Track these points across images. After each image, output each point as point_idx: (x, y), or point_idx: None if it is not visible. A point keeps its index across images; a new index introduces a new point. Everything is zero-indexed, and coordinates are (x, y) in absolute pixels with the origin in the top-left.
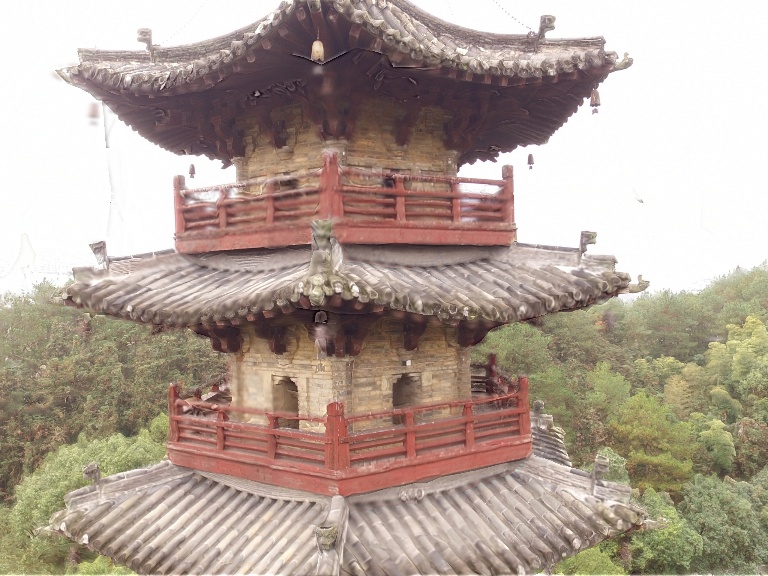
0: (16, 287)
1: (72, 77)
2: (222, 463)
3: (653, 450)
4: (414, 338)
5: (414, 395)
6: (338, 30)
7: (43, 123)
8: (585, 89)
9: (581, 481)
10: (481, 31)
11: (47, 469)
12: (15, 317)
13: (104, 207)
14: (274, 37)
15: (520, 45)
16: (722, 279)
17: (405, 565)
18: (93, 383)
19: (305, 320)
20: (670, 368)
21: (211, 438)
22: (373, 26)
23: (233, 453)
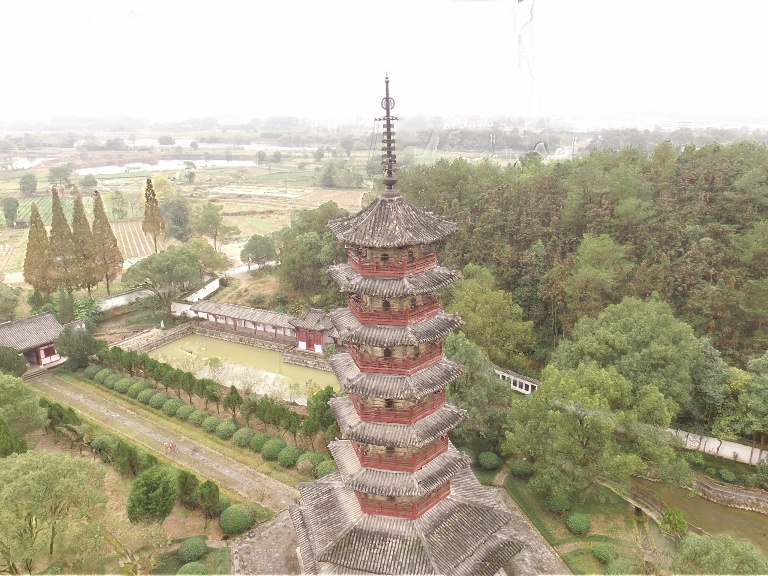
0: (428, 161)
1: None
2: None
3: None
4: None
5: None
6: None
7: (473, 4)
8: None
9: None
10: None
11: None
12: None
13: (513, 72)
14: None
15: None
16: None
17: (365, 337)
18: None
19: None
20: None
21: None
22: (354, 243)
23: None
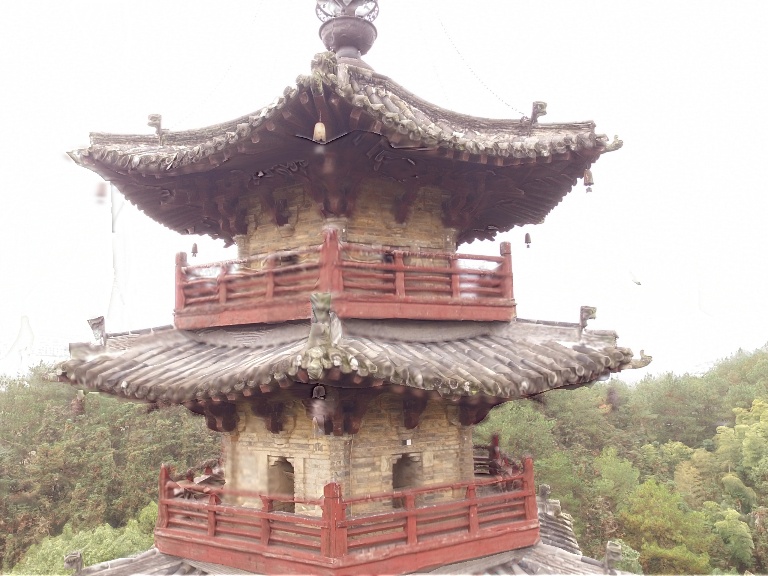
0: (12, 370)
1: (82, 158)
2: (212, 551)
3: (667, 542)
4: (414, 416)
5: (415, 477)
6: (339, 113)
7: (52, 209)
8: (578, 169)
9: (593, 571)
10: (476, 117)
11: (28, 563)
12: (8, 401)
13: (106, 290)
14: (278, 119)
15: (514, 129)
16: (725, 361)
17: None
18: (83, 470)
19: (303, 395)
20: (679, 454)
21: (202, 523)
22: (373, 109)
23: (224, 540)
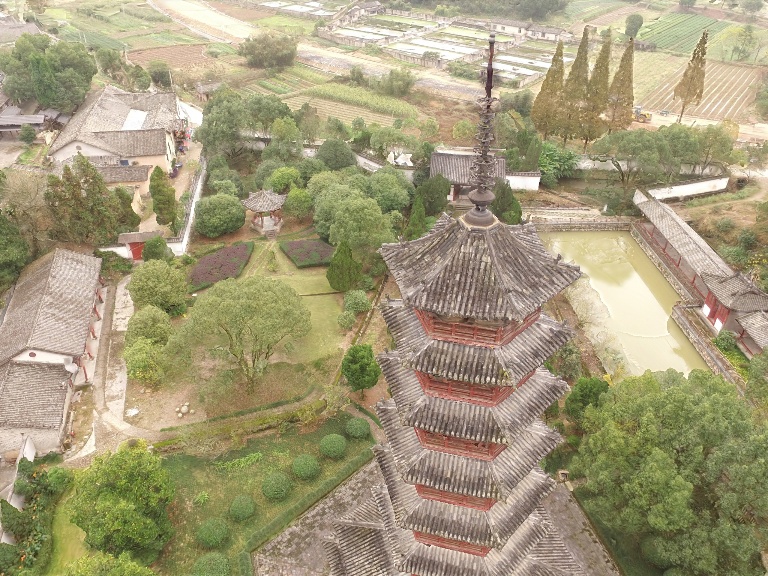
0: None
1: None
2: None
3: None
4: None
5: None
6: None
7: None
8: None
9: None
10: None
11: None
12: None
13: None
14: None
15: None
16: None
17: None
18: None
19: None
20: None
21: None
22: None
23: None
